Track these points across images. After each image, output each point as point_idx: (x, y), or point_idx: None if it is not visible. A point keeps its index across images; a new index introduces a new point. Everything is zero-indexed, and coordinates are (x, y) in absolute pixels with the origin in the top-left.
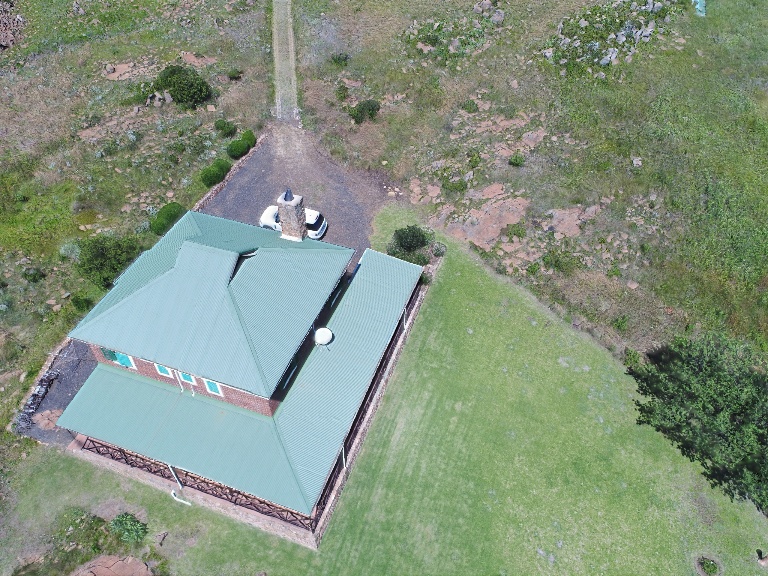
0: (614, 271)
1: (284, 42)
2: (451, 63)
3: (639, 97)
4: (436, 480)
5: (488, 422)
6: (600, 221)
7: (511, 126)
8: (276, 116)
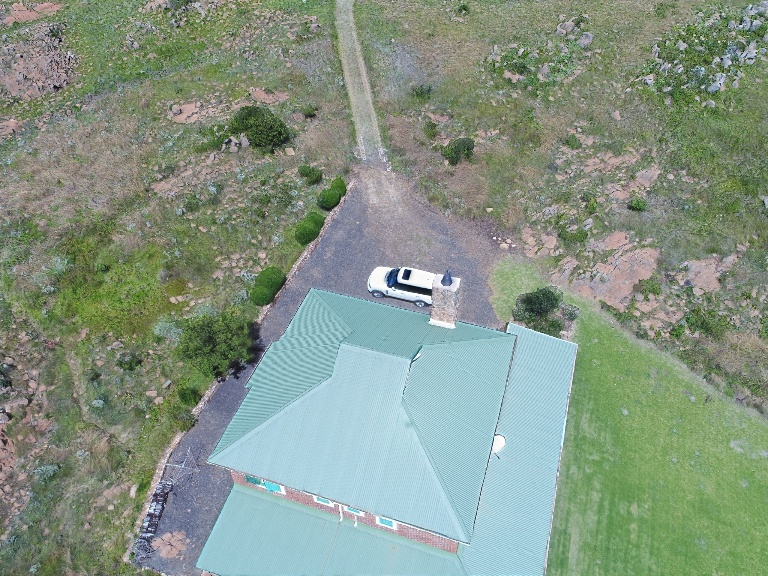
0: (766, 332)
1: (355, 73)
2: (542, 93)
3: (755, 127)
4: None
5: (672, 529)
6: (741, 273)
7: (621, 164)
8: (361, 158)
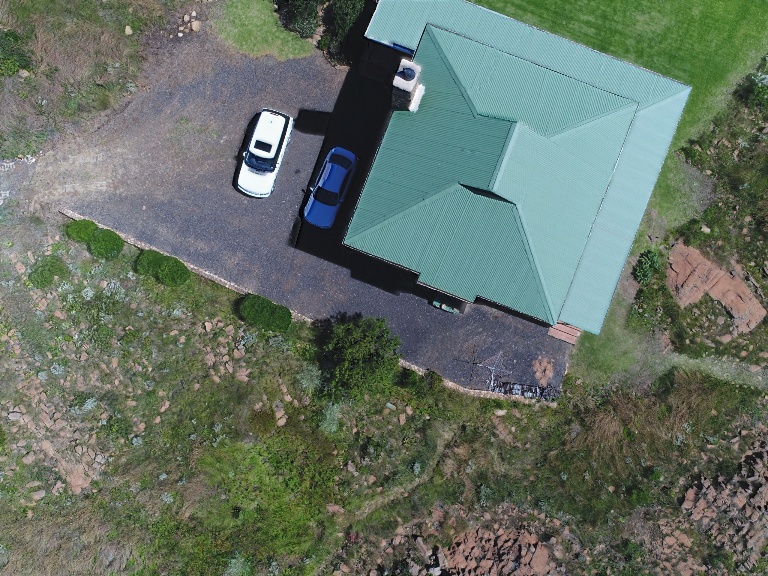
0: None
1: None
2: None
3: None
4: (599, 8)
5: None
6: None
7: None
8: (3, 200)
